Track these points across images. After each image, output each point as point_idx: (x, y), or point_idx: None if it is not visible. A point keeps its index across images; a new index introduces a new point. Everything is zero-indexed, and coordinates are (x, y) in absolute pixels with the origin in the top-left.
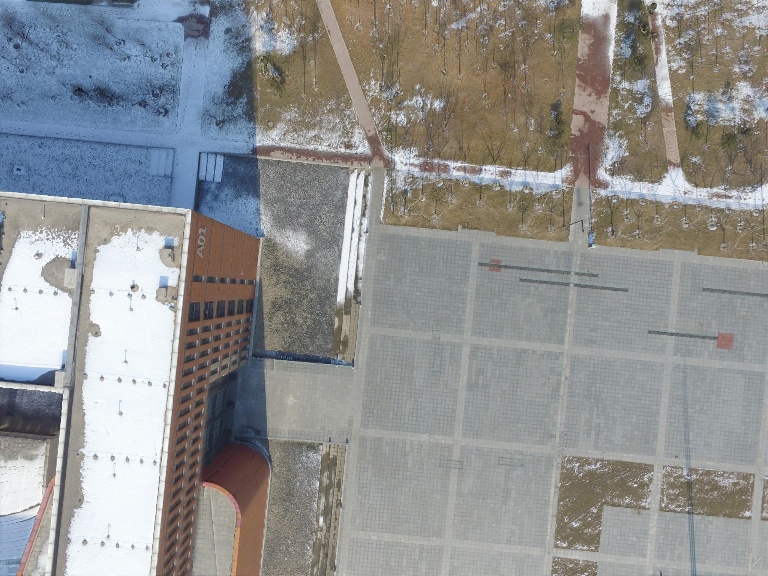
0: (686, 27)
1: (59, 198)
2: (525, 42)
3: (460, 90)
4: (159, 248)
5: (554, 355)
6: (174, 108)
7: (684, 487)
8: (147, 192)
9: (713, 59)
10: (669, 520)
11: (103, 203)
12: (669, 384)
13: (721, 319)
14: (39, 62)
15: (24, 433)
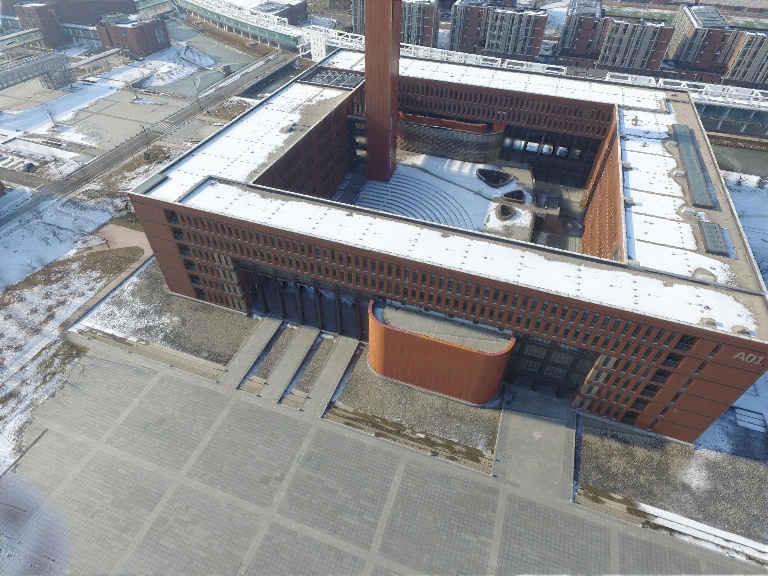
0: None
1: (763, 283)
2: None
3: None
4: None
5: None
6: None
7: None
8: None
9: None
10: None
11: None
12: None
13: None
14: None
15: None
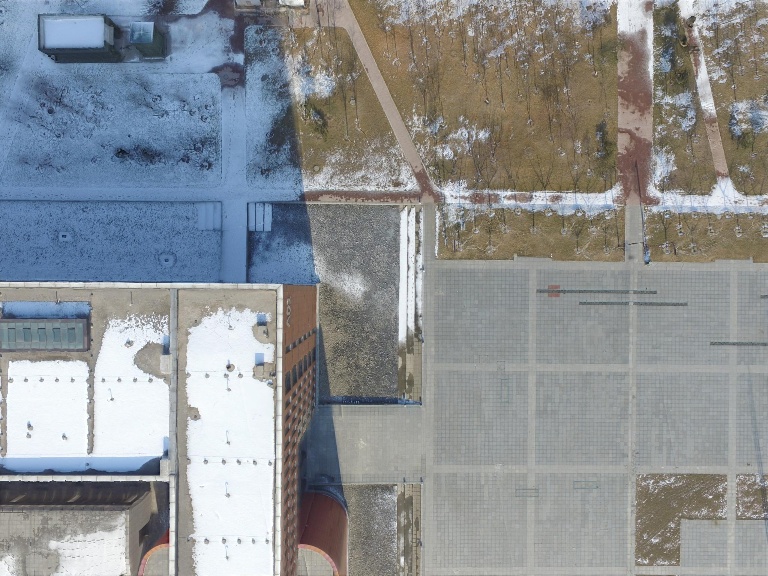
0: (723, 36)
1: (147, 284)
2: (565, 65)
3: (504, 118)
4: (252, 325)
5: (620, 375)
6: (217, 160)
7: (758, 494)
8: (197, 248)
9: (753, 66)
10: (746, 528)
11: (192, 285)
12: (735, 393)
13: None
14: (75, 125)
15: (100, 505)
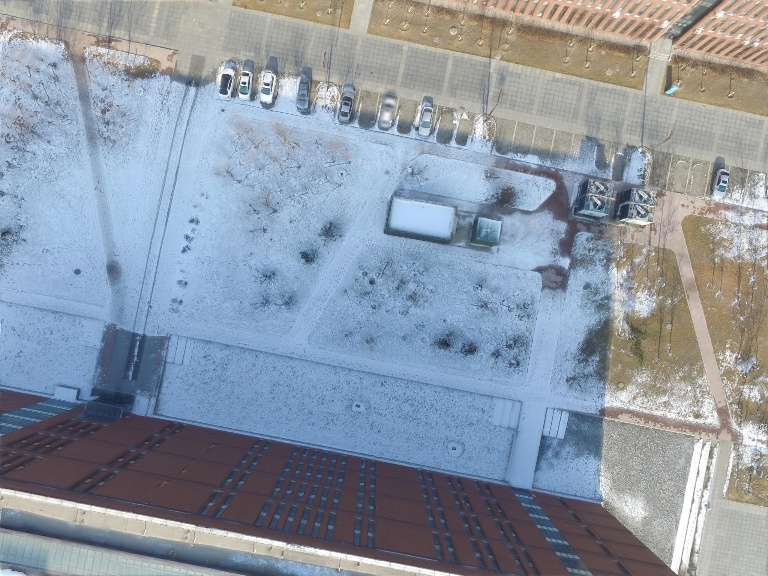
0: None
1: None
2: None
3: None
4: None
5: None
6: (525, 360)
7: None
8: (488, 442)
9: None
10: None
11: None
12: None
13: None
14: (393, 300)
15: None
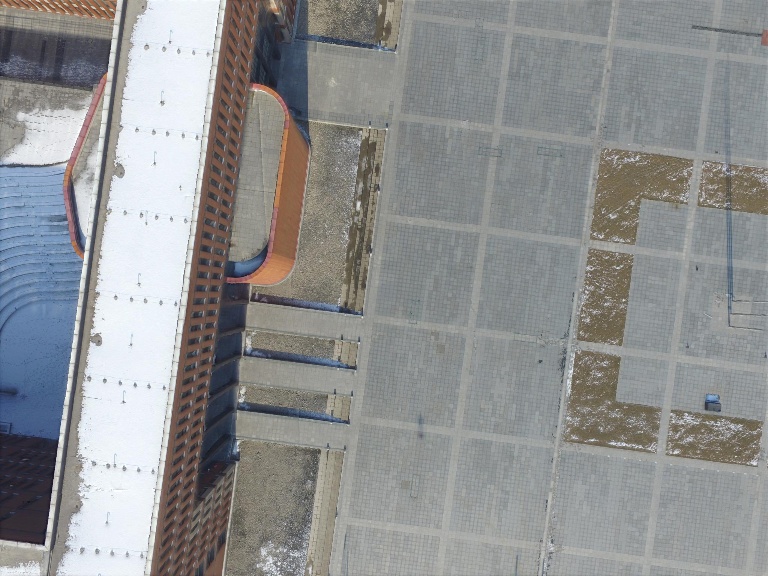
0: None
1: None
2: None
3: None
4: None
5: (597, 47)
6: None
7: (723, 182)
8: None
9: None
10: (707, 215)
11: None
12: (712, 79)
13: (766, 16)
14: None
15: None
